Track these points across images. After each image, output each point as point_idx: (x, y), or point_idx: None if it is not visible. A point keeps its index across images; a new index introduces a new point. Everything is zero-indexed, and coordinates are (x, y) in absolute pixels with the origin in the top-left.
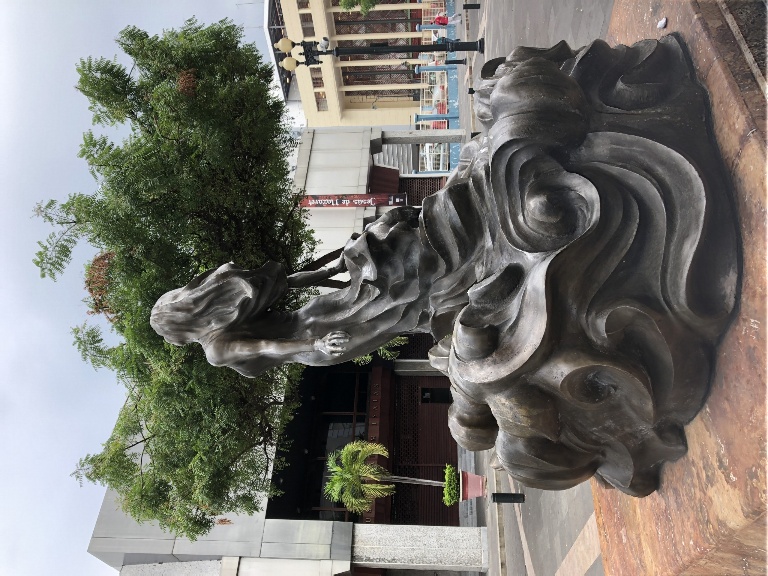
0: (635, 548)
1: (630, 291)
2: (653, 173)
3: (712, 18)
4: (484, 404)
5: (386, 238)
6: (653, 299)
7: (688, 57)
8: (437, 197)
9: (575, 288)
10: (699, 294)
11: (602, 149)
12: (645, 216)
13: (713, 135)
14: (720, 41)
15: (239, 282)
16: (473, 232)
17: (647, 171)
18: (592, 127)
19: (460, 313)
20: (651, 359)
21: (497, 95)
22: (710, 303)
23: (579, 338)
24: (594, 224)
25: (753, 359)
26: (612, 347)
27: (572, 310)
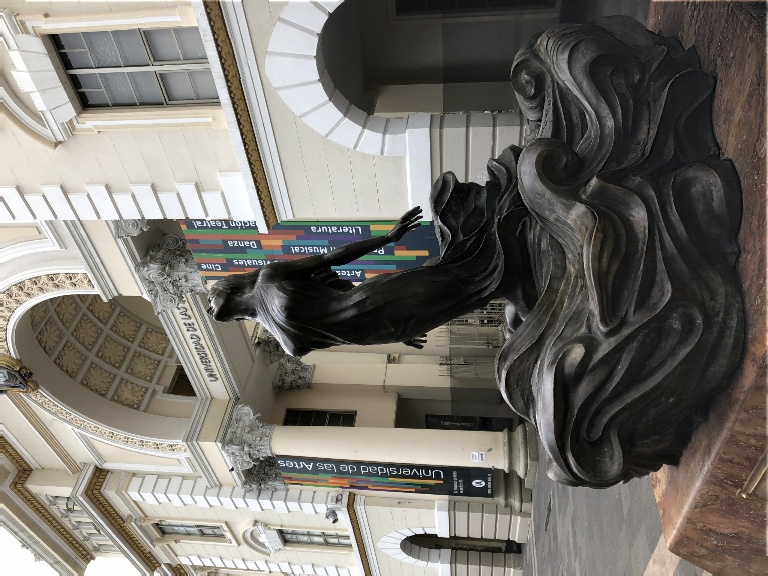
0: (756, 104)
1: None
2: None
3: None
4: None
5: None
6: None
7: None
8: None
9: None
10: None
11: None
12: None
13: None
14: None
15: None
16: None
17: None
18: None
19: None
20: None
21: None
22: None
23: None
24: None
25: None
26: None
27: None
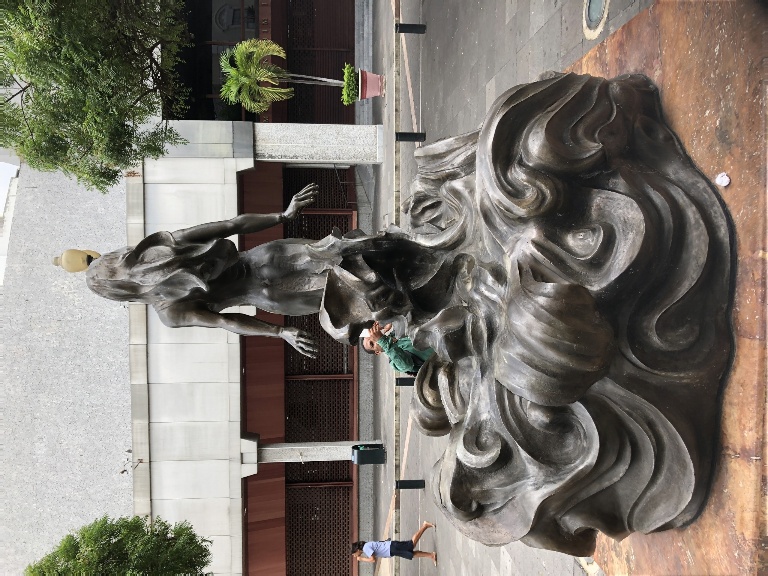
0: None
1: (602, 506)
2: (655, 429)
3: None
4: (445, 414)
5: (367, 322)
6: (619, 520)
7: (733, 281)
8: (431, 334)
9: (558, 505)
10: None
11: (615, 393)
12: (634, 456)
13: (722, 394)
14: None
15: (189, 275)
16: None
17: (650, 426)
18: (611, 372)
19: (448, 467)
20: None
21: (521, 335)
22: None
23: (550, 525)
24: (588, 467)
25: (679, 569)
26: (575, 535)
27: (550, 513)
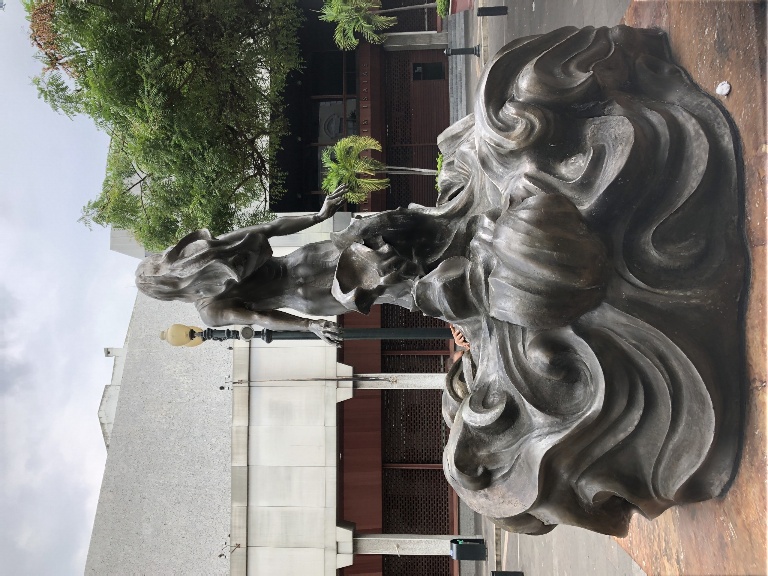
0: None
1: (622, 467)
2: (667, 363)
3: None
4: None
5: (376, 289)
6: (642, 484)
7: (742, 189)
8: (431, 285)
9: (568, 464)
10: (688, 486)
11: (616, 322)
12: (650, 401)
13: (744, 320)
14: None
15: (221, 266)
16: (469, 316)
17: (661, 360)
18: (609, 296)
19: (455, 431)
20: None
21: (502, 251)
22: (697, 489)
23: (567, 495)
24: (595, 412)
25: (723, 550)
26: (597, 507)
27: (563, 476)
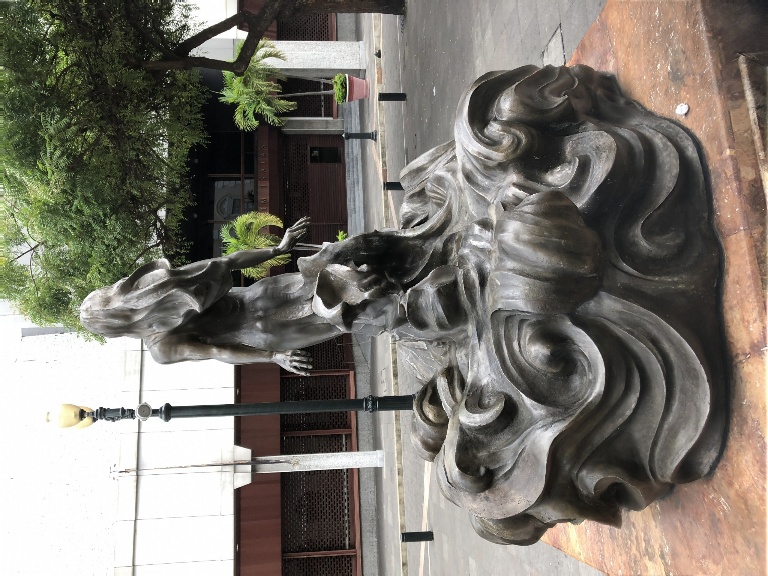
0: None
1: (620, 454)
2: (659, 346)
3: (746, 163)
4: None
5: (360, 304)
6: (640, 467)
7: (709, 190)
8: (423, 293)
9: (571, 453)
10: (681, 466)
11: (612, 310)
12: (644, 385)
13: (721, 304)
14: (750, 204)
15: (182, 295)
16: (458, 324)
17: (654, 343)
18: (605, 285)
19: (451, 436)
20: (625, 494)
21: (510, 243)
22: (688, 469)
23: (568, 488)
24: (597, 397)
25: (716, 526)
26: (596, 498)
27: (565, 468)
